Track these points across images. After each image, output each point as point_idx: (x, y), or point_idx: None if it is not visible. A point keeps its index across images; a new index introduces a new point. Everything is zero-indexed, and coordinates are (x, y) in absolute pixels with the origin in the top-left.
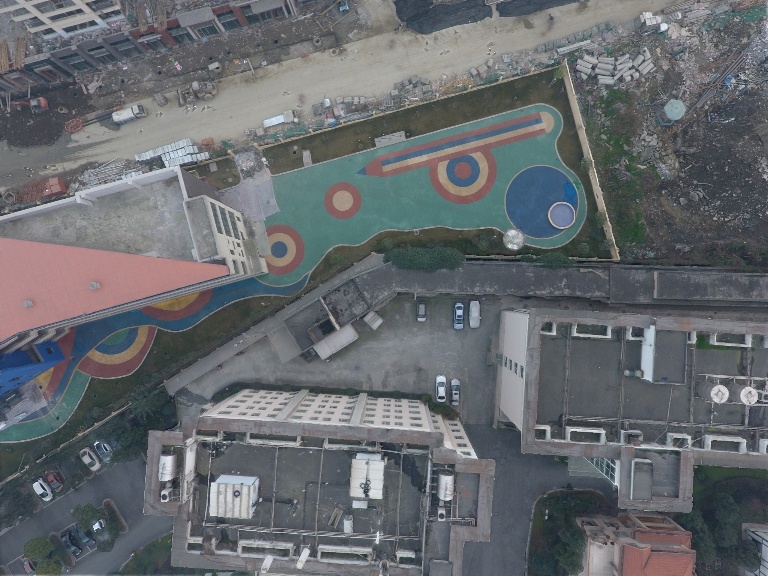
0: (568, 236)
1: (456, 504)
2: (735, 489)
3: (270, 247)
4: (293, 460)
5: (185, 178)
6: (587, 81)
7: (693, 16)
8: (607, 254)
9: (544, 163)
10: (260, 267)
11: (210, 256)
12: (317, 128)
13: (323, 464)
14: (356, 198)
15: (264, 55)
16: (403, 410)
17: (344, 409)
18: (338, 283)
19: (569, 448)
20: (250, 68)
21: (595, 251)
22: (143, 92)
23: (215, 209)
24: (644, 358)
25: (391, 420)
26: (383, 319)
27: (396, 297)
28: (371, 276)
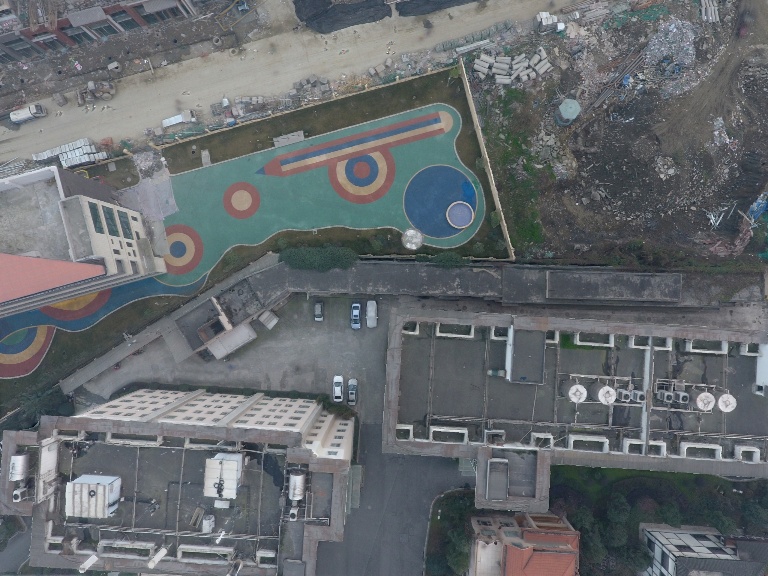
0: (466, 236)
1: (311, 504)
2: (632, 489)
3: (169, 247)
4: (155, 460)
5: (64, 178)
6: (486, 81)
7: (592, 15)
8: (505, 254)
9: (443, 163)
10: (154, 267)
11: (85, 256)
12: (216, 128)
13: (185, 464)
14: (255, 198)
15: (165, 55)
16: (289, 410)
17: (227, 409)
18: (233, 283)
19: (430, 448)
20: (150, 68)
21: (493, 251)
22: (44, 92)
23: (96, 209)
24: (507, 358)
25: (267, 420)
26: (281, 319)
27: (294, 297)
28: (264, 276)
